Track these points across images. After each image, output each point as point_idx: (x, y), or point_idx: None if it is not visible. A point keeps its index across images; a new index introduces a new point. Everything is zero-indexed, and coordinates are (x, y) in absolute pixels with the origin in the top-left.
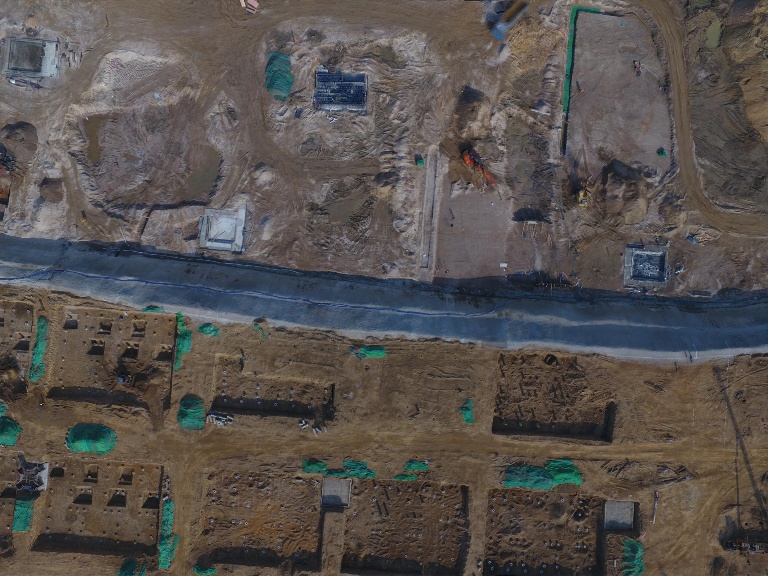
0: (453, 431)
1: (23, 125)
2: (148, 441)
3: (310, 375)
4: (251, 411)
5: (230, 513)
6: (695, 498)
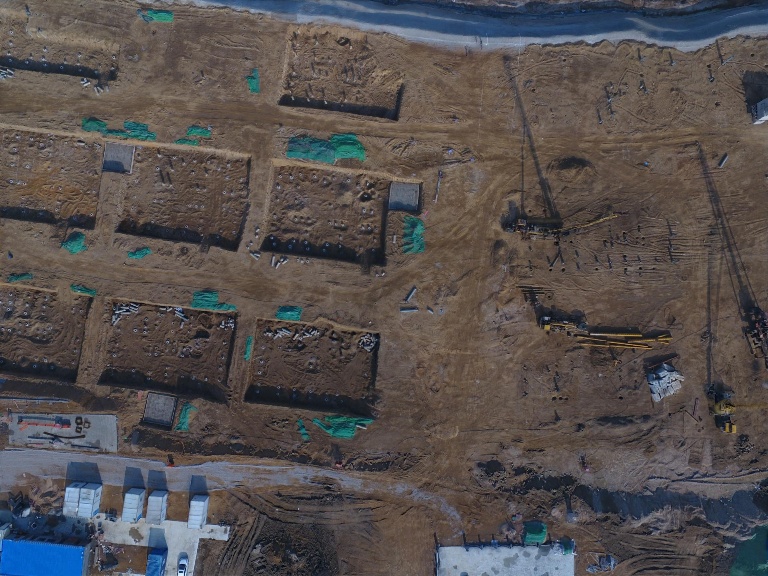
0: (238, 100)
1: None
2: None
3: (95, 35)
4: None
5: (9, 173)
6: (479, 180)
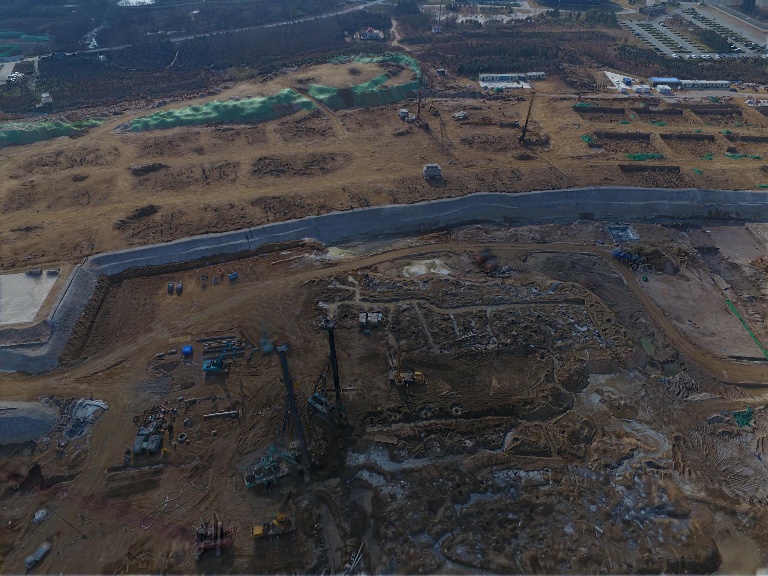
0: None
1: None
2: None
3: None
4: None
5: None
6: (568, 152)
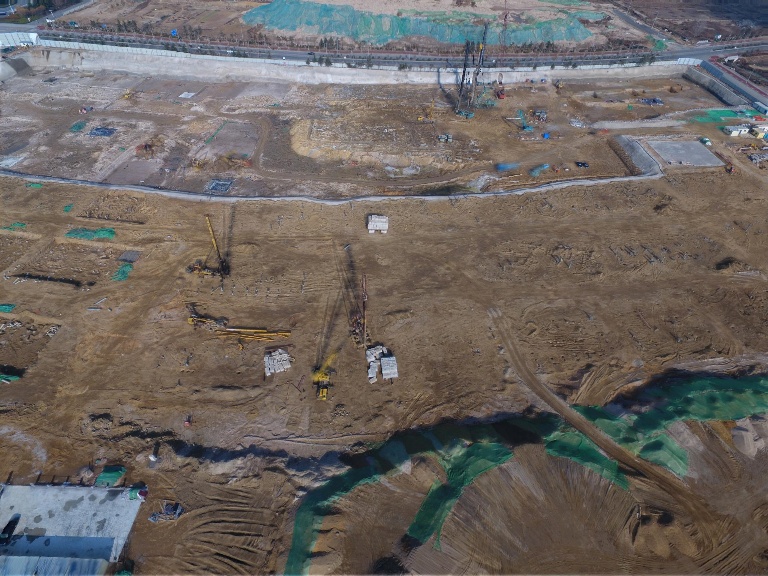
0: (54, 214)
1: None
2: None
3: None
4: None
5: None
6: (181, 249)
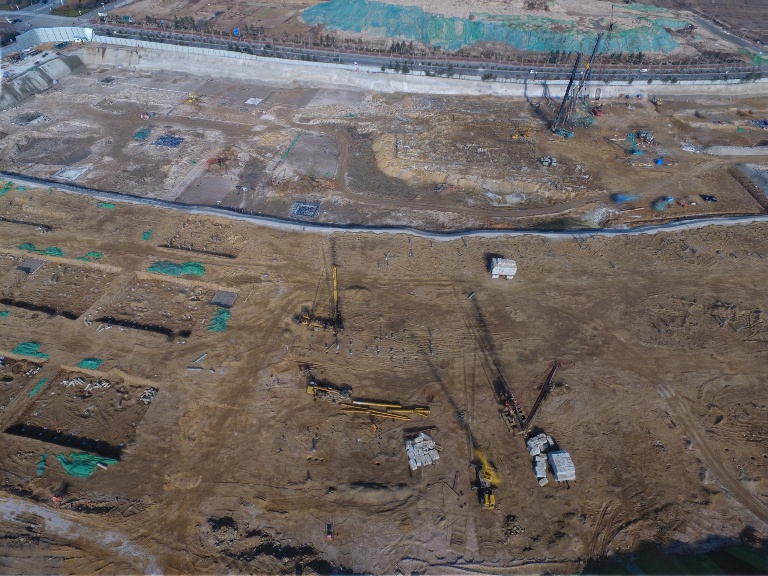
0: (132, 242)
1: (3, 132)
2: None
3: (62, 210)
4: None
5: None
6: (282, 292)
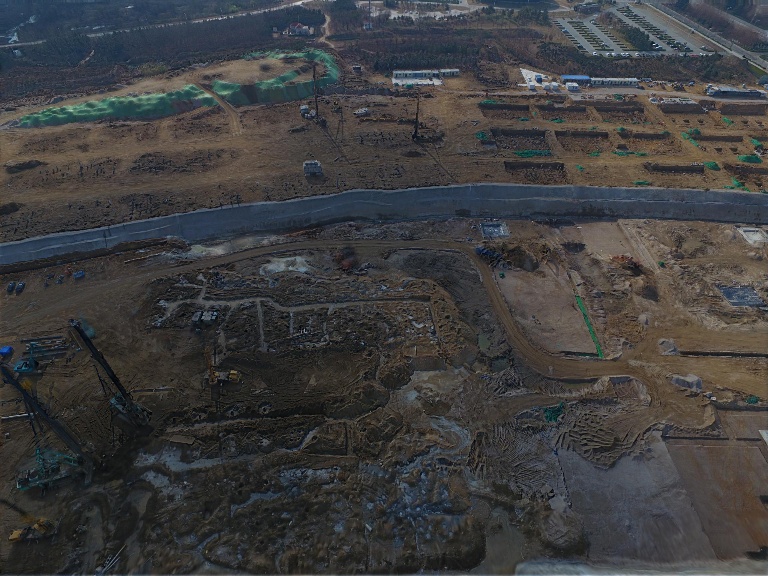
0: None
1: None
2: (723, 159)
3: (666, 176)
4: (683, 169)
5: None
6: (458, 149)
